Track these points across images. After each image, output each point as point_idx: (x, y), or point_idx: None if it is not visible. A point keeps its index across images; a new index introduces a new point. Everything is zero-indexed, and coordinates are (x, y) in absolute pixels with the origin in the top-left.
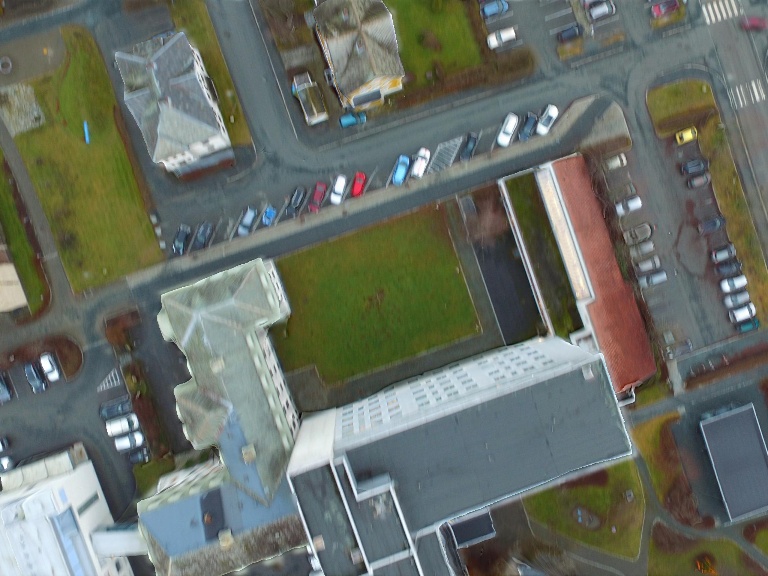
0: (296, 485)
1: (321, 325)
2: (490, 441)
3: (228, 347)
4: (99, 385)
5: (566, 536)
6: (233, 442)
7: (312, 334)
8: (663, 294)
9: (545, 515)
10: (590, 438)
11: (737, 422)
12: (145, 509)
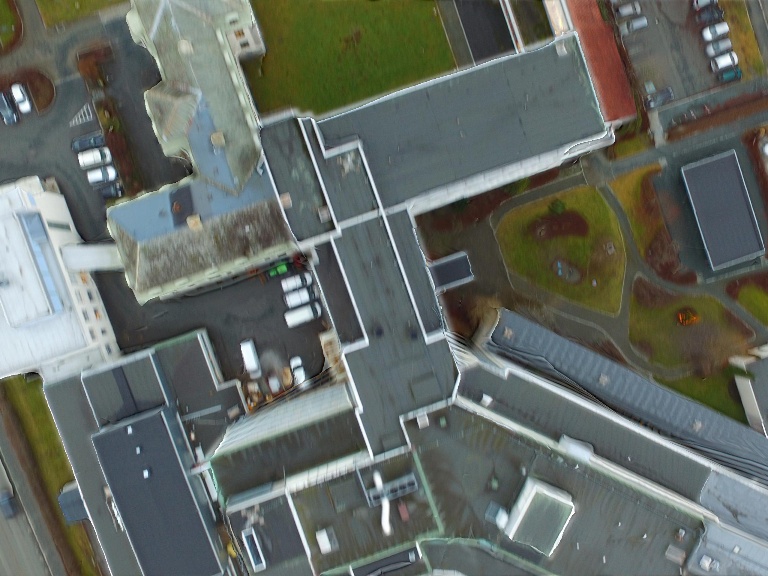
0: (262, 138)
1: (296, 65)
2: (462, 116)
3: (197, 35)
4: (71, 120)
5: (546, 290)
6: (202, 133)
7: (287, 74)
8: (644, 43)
9: (525, 267)
10: (564, 117)
11: (719, 168)
12: (114, 208)
